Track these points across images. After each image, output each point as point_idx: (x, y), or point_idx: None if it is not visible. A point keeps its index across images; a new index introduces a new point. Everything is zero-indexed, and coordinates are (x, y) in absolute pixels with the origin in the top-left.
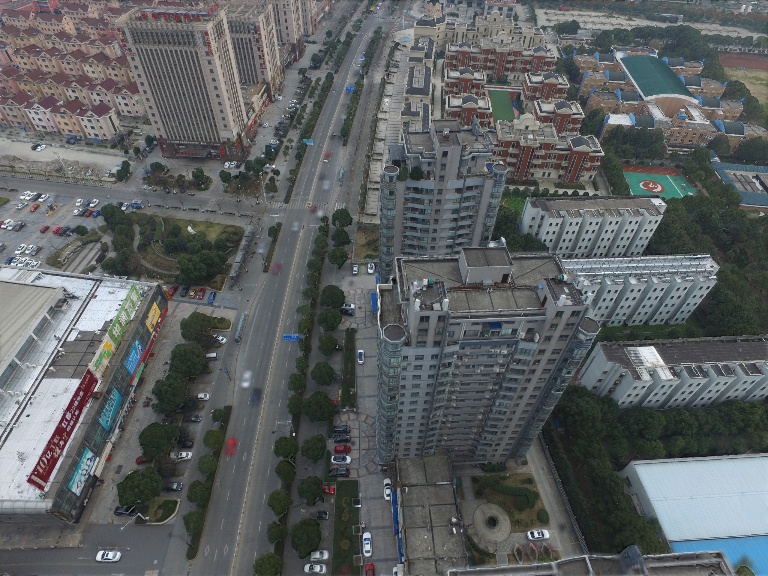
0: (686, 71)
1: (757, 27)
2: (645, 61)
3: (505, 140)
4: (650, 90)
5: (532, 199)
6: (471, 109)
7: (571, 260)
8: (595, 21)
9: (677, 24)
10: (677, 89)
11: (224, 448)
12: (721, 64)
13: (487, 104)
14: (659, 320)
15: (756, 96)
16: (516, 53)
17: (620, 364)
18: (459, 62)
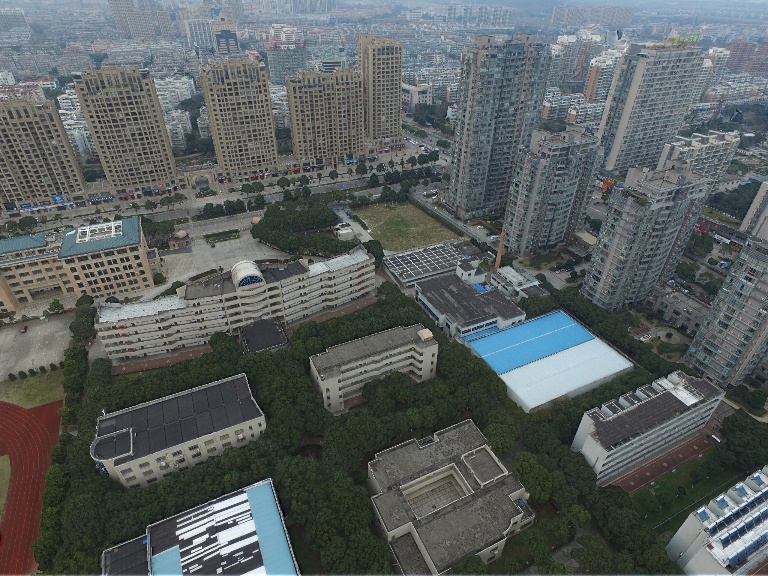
0: None
1: None
2: None
3: None
4: None
5: None
6: None
7: None
8: None
9: None
10: None
11: None
12: None
13: None
14: None
15: None
16: None
17: (697, 381)
18: None
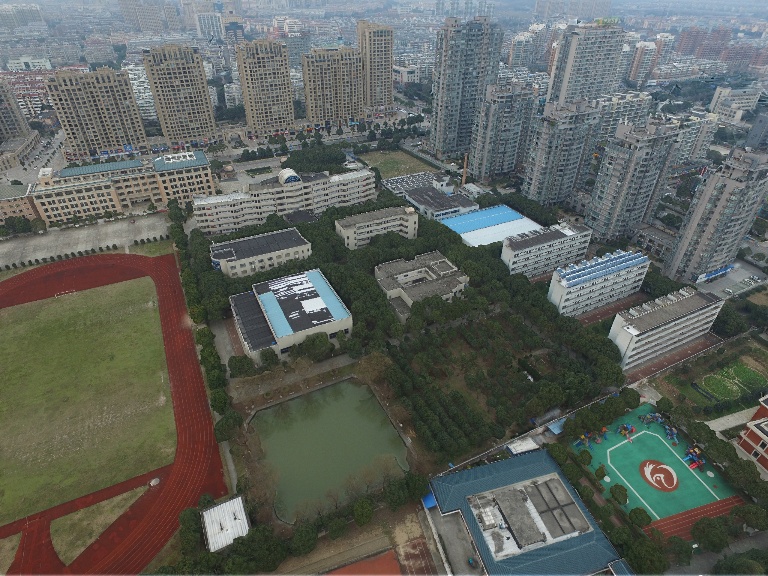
0: None
1: None
2: None
3: None
4: None
5: (721, 303)
6: None
7: (642, 257)
8: None
9: None
10: None
11: (680, 215)
12: None
13: None
14: None
15: None
16: None
17: (578, 226)
18: None
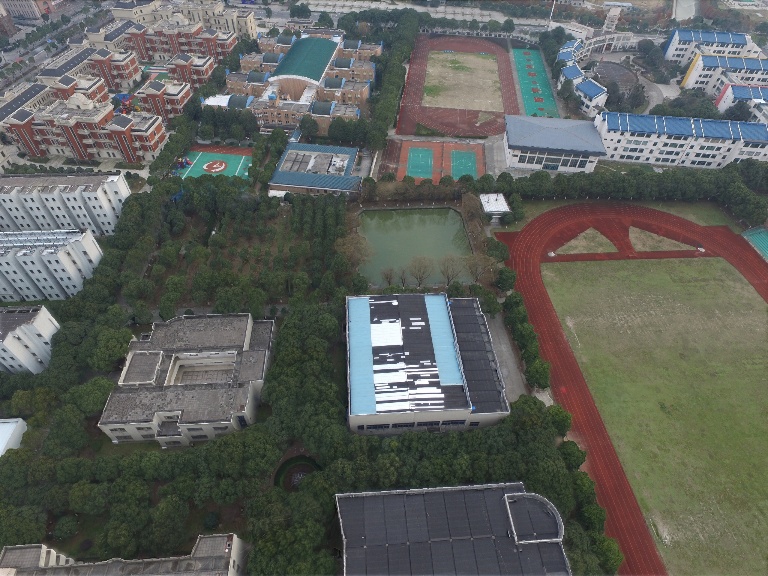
0: (361, 53)
1: (509, 11)
2: (309, 43)
3: (47, 119)
4: (278, 71)
5: None
6: (62, 89)
7: None
8: (355, 5)
9: (435, 8)
10: (304, 70)
11: None
12: (433, 47)
13: (88, 85)
14: (55, 295)
15: (431, 79)
16: (187, 35)
17: None
18: (135, 44)
